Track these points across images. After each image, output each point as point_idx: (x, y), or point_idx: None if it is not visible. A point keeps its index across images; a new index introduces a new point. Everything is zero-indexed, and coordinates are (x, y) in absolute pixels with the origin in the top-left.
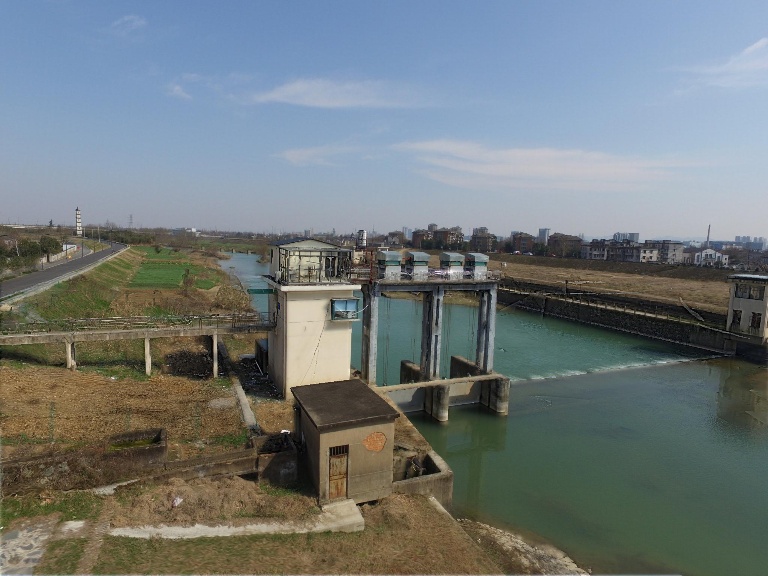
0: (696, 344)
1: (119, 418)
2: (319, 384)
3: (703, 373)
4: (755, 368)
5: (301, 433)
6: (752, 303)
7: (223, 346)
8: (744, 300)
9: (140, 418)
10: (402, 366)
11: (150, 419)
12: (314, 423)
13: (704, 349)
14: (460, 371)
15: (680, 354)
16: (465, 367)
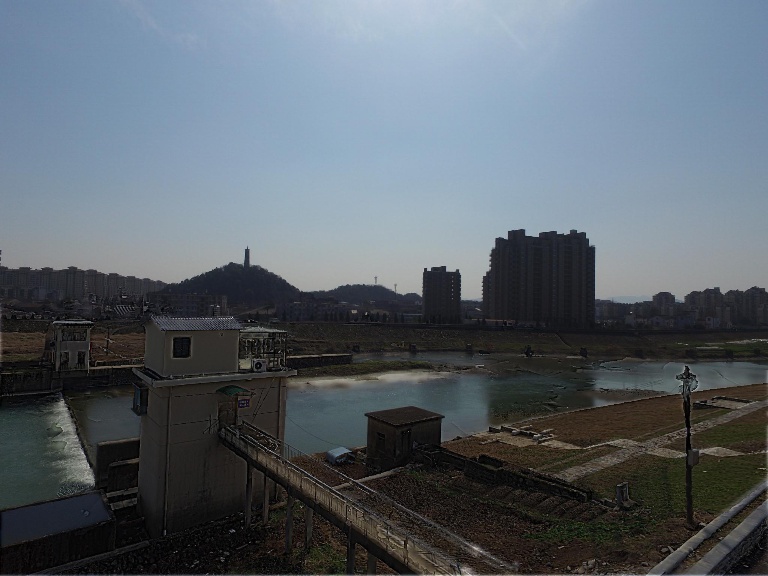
0: (21, 392)
1: (434, 519)
2: (385, 419)
3: (35, 416)
4: (100, 393)
5: (412, 444)
6: (78, 344)
7: (48, 569)
8: (71, 343)
9: (422, 512)
10: (122, 469)
11: (418, 508)
12: (441, 417)
13: (30, 394)
14: (123, 455)
15: (15, 405)
16: (134, 446)
